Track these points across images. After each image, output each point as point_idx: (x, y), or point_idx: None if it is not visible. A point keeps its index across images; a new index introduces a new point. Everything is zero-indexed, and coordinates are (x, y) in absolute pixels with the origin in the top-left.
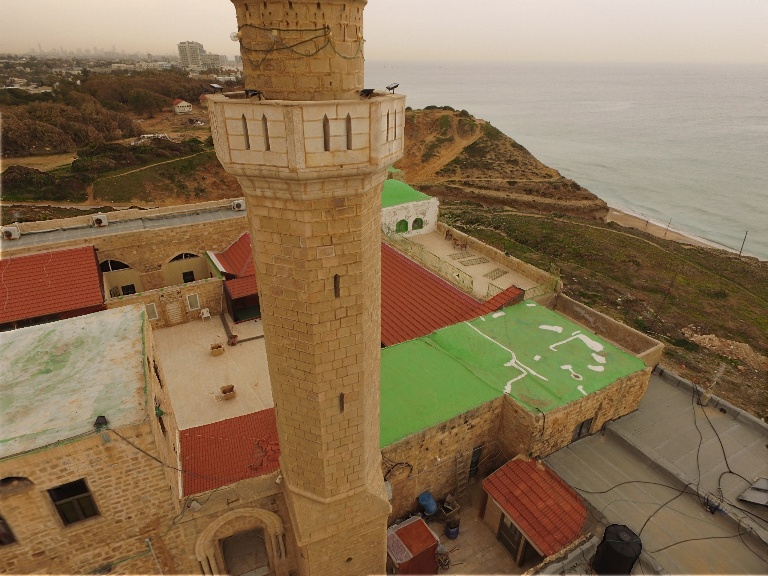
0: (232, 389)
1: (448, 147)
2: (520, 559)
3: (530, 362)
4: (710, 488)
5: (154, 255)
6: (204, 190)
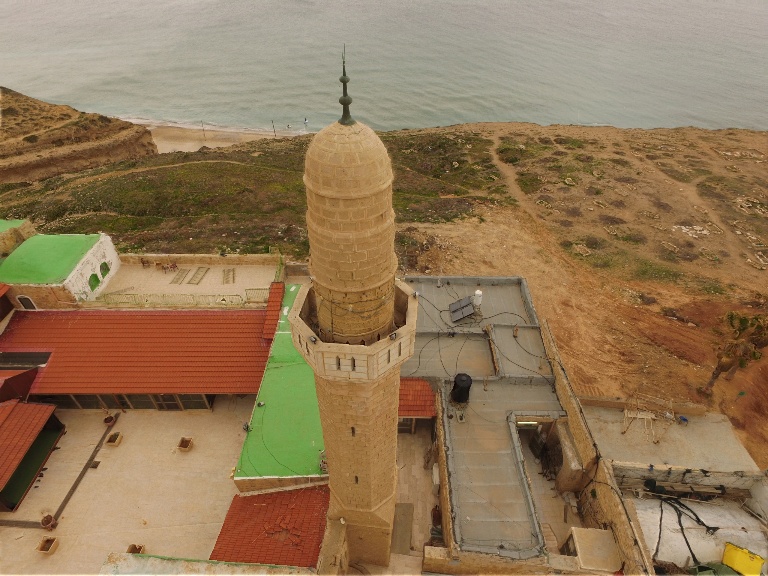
0: (135, 548)
1: None
2: (414, 430)
3: None
4: (443, 326)
5: None
6: None
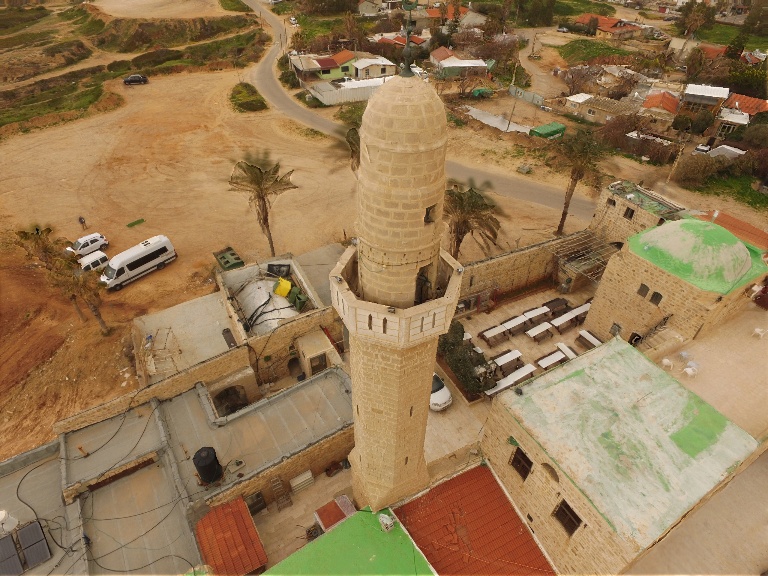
0: None
1: None
2: None
3: None
4: (64, 567)
5: None
6: None
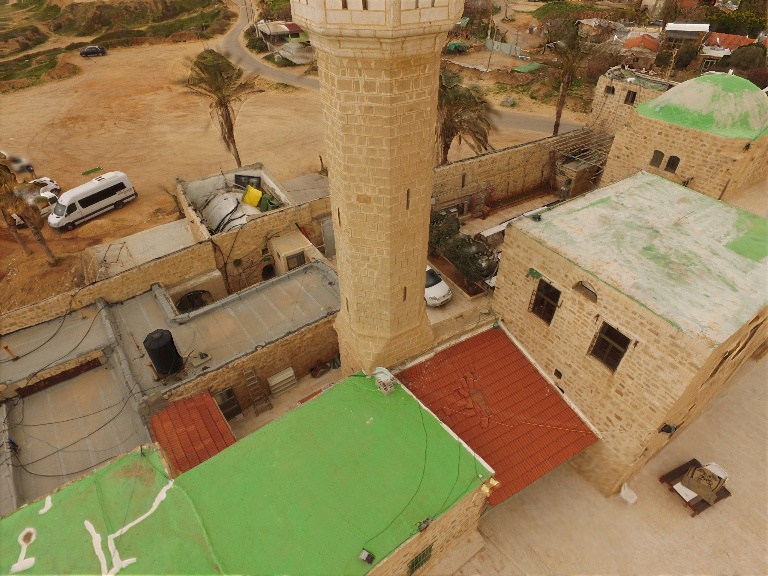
0: None
1: None
2: None
3: (82, 572)
4: None
5: None
6: None
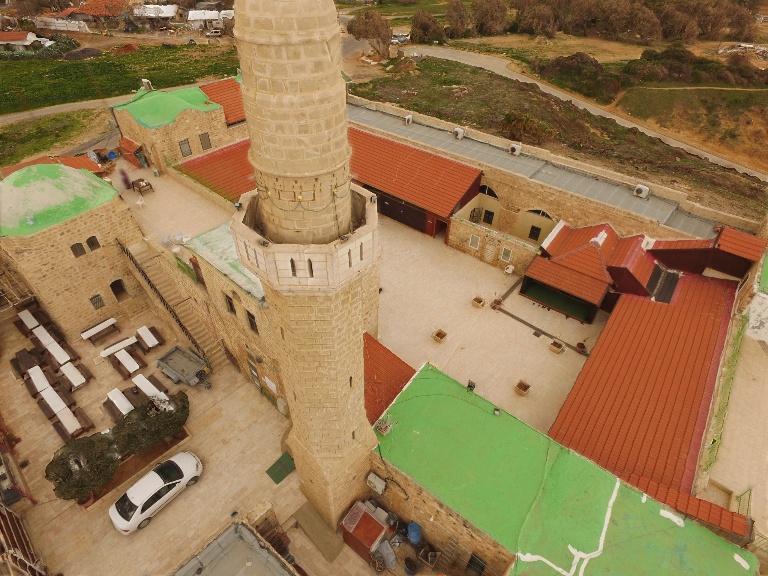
0: (444, 336)
1: None
2: None
3: None
4: None
5: (519, 199)
6: (736, 136)
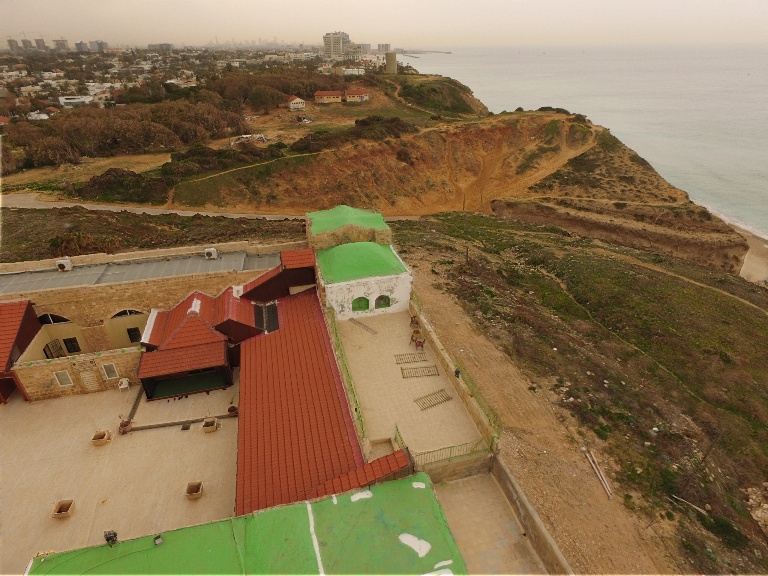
0: (70, 506)
1: (551, 158)
2: None
3: None
4: None
5: (94, 311)
6: (276, 197)
